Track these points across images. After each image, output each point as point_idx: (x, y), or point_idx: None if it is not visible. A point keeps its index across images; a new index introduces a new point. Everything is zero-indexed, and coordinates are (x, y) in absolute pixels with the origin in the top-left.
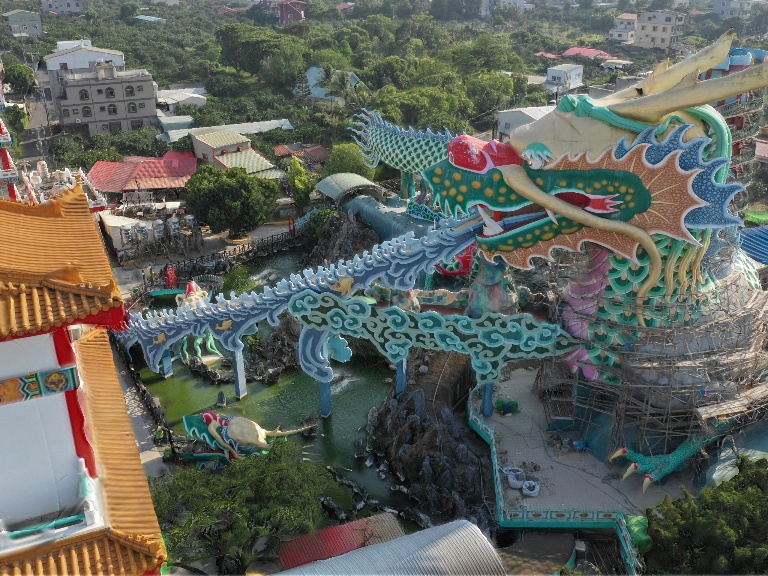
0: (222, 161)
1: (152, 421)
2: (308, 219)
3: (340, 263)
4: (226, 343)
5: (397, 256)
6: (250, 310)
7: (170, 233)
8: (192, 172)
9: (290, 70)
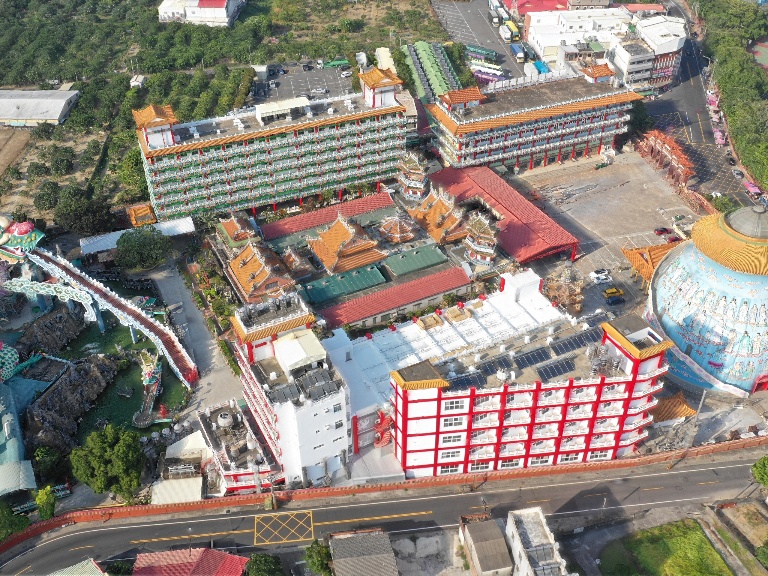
0: None
1: (172, 321)
2: None
3: None
4: None
5: None
6: None
7: None
8: (137, 571)
9: None
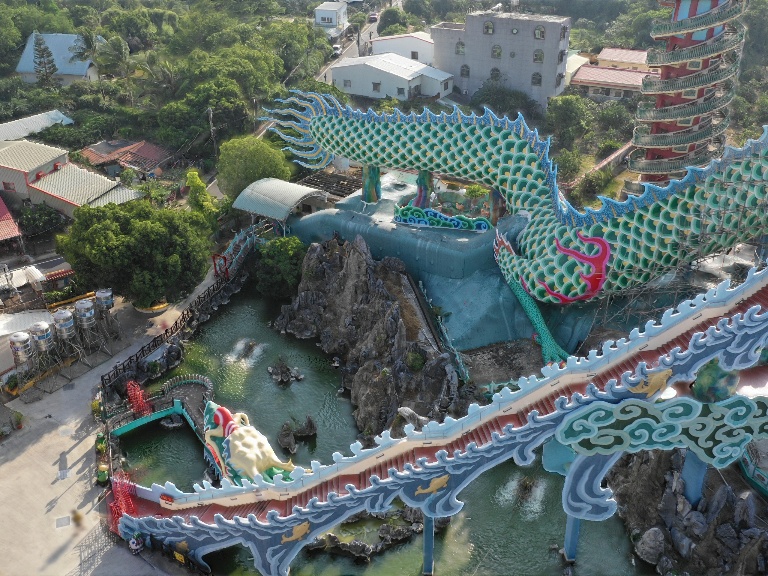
0: (44, 189)
1: None
2: (233, 252)
3: (607, 346)
4: (432, 509)
5: (747, 324)
6: (484, 453)
7: (82, 325)
8: (3, 214)
9: (2, 41)
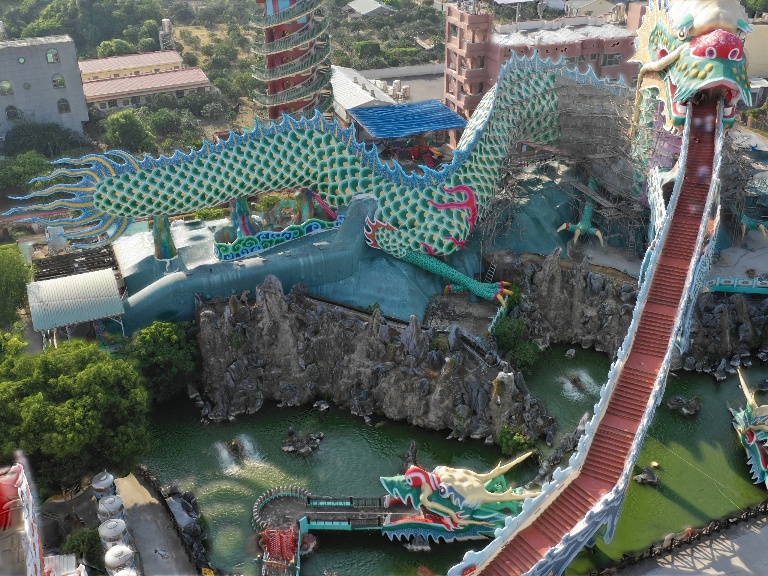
0: None
1: (741, 526)
2: None
3: None
4: None
5: None
6: None
7: None
8: None
9: None
